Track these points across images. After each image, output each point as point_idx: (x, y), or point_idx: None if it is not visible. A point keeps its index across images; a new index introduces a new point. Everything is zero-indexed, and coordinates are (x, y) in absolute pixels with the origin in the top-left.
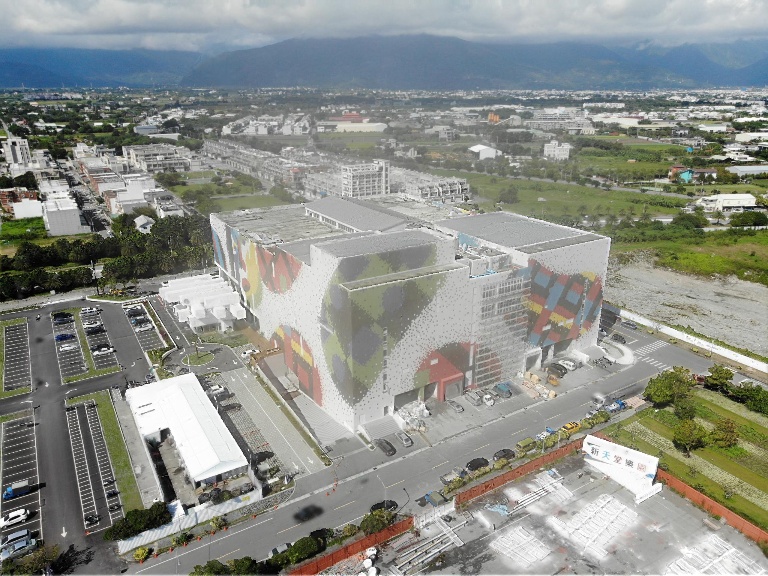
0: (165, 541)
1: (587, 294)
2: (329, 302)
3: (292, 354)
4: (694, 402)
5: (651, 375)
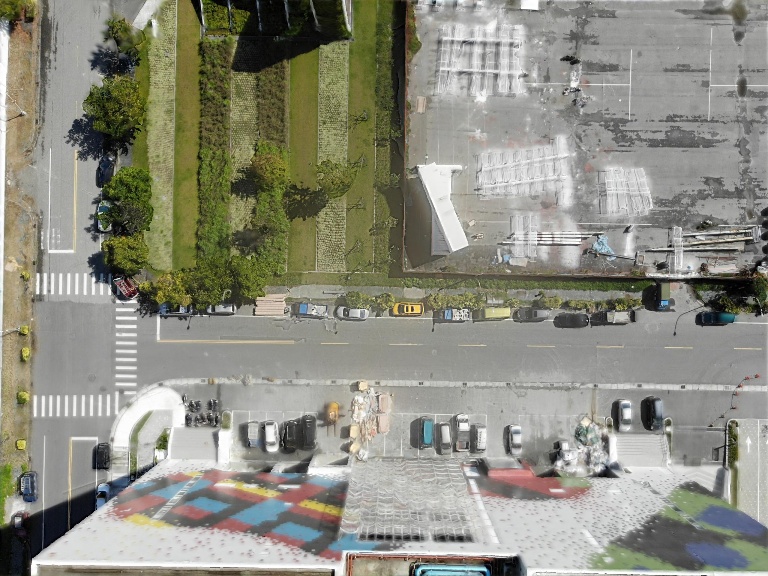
0: None
1: (164, 504)
2: None
3: None
4: (206, 250)
5: (173, 343)
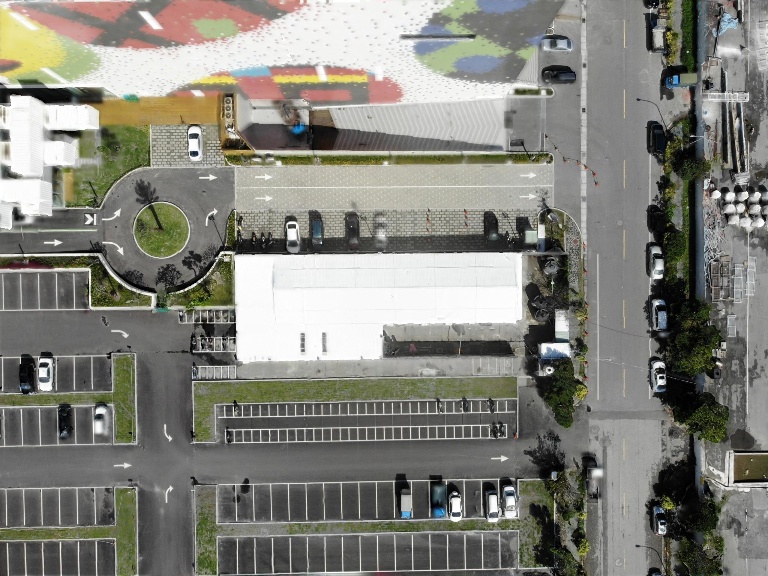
0: None
1: None
2: (469, 12)
3: (279, 88)
4: None
5: None
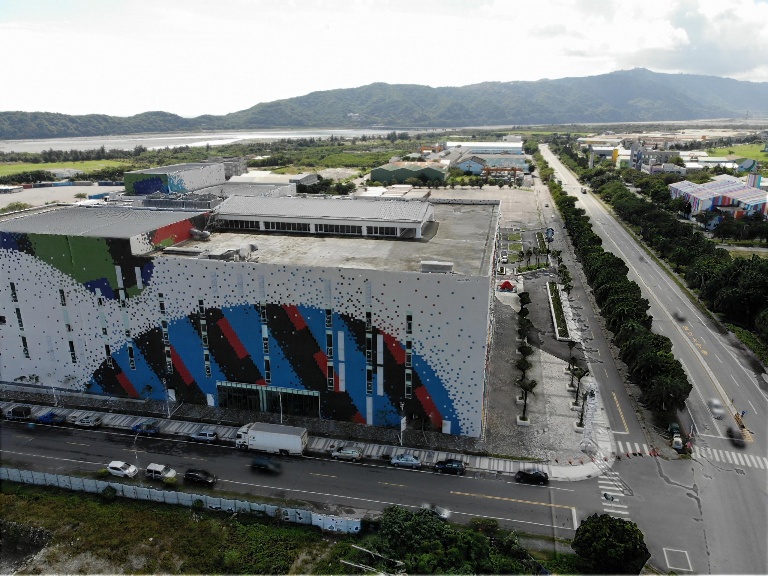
0: None
1: None
2: None
3: None
4: None
5: None
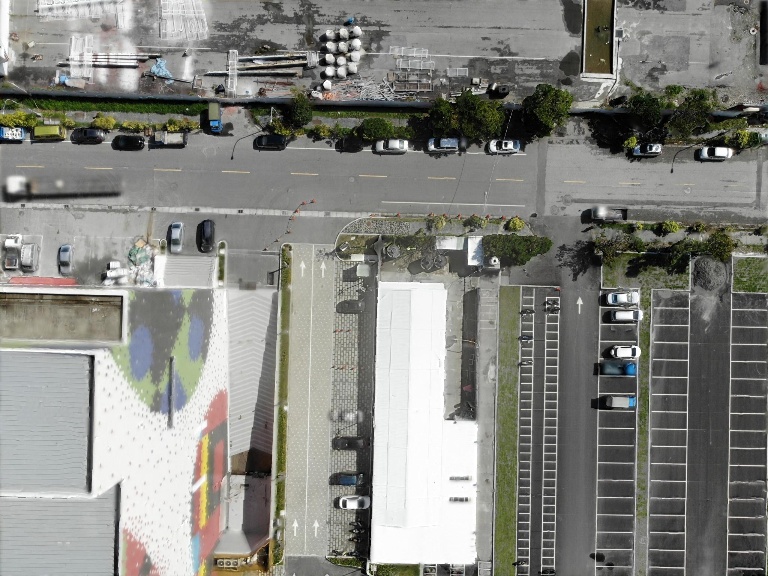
0: (492, 232)
1: None
2: None
3: None
4: None
5: None
